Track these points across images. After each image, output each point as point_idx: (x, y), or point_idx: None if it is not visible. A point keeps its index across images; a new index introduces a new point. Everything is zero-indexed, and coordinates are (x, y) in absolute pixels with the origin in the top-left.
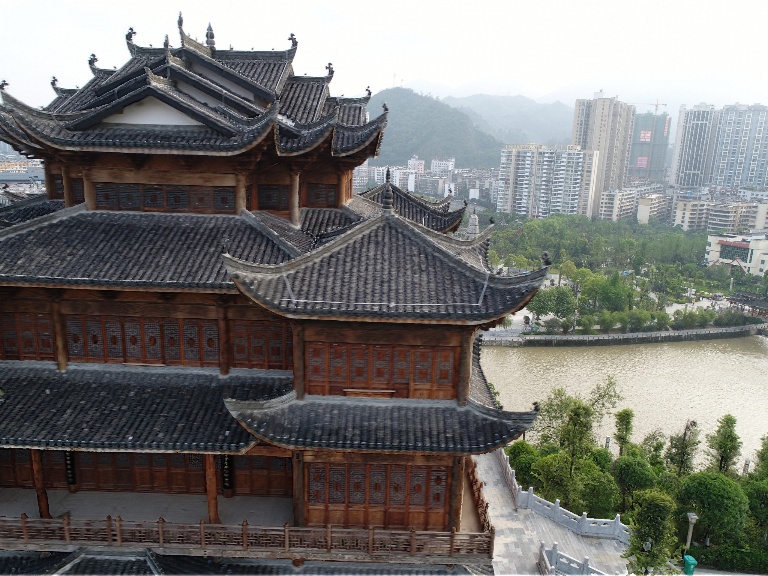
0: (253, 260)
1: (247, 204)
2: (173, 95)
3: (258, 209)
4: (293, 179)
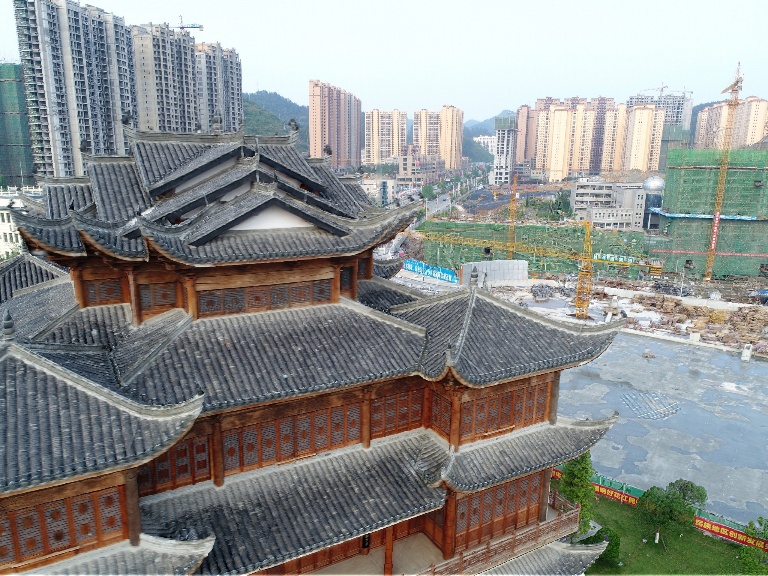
0: None
1: None
2: None
3: None
4: None
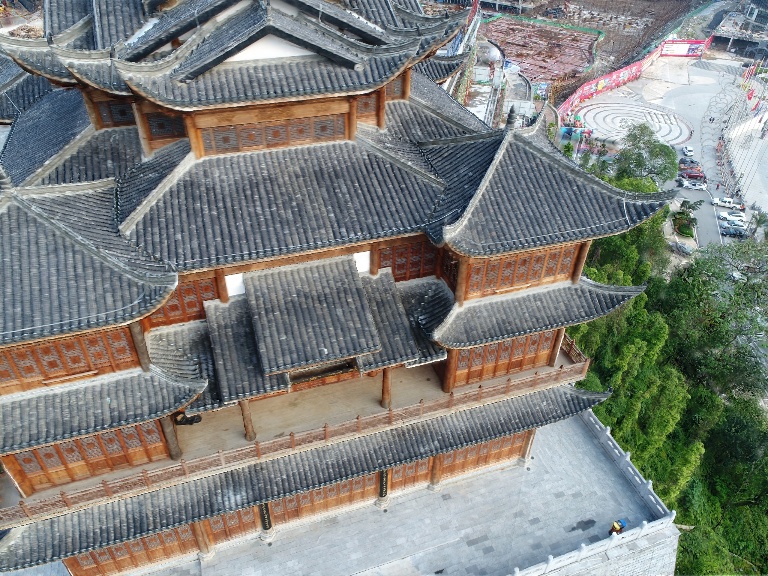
0: (21, 178)
1: (120, 118)
2: None
3: None
4: (132, 107)
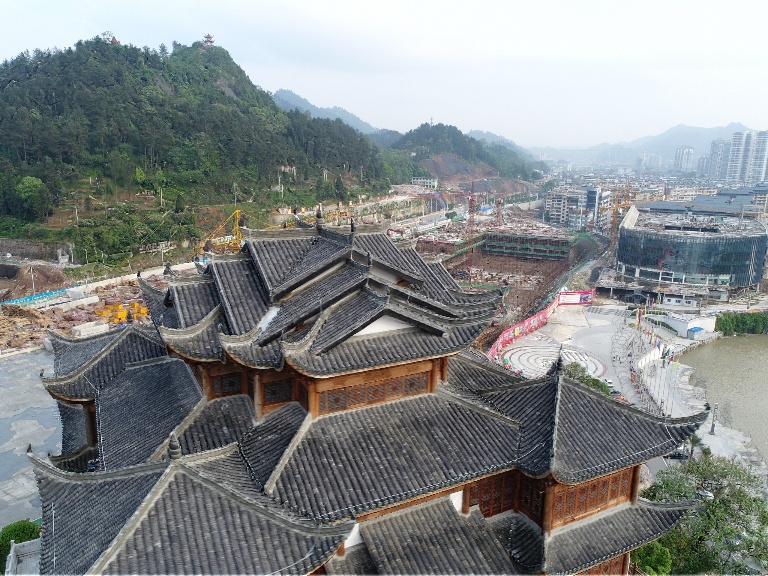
0: None
1: (228, 389)
2: (175, 296)
3: (248, 394)
4: (253, 378)
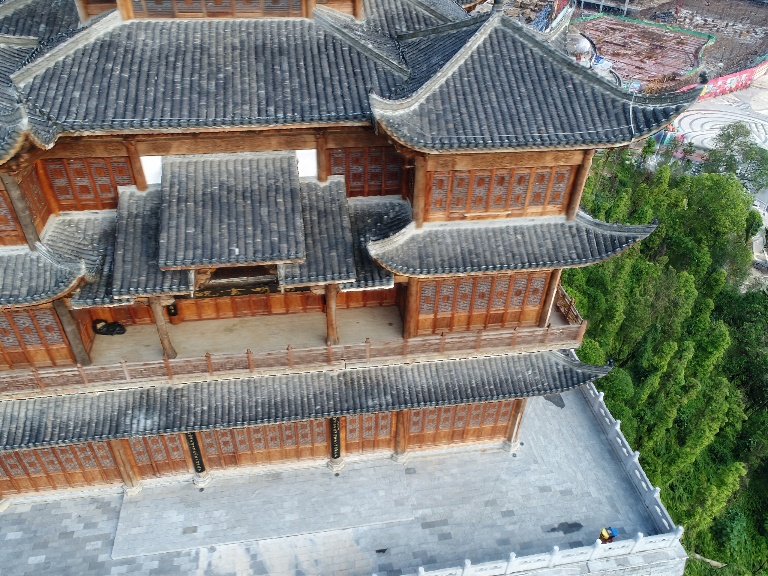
0: None
1: None
2: None
3: None
4: None
